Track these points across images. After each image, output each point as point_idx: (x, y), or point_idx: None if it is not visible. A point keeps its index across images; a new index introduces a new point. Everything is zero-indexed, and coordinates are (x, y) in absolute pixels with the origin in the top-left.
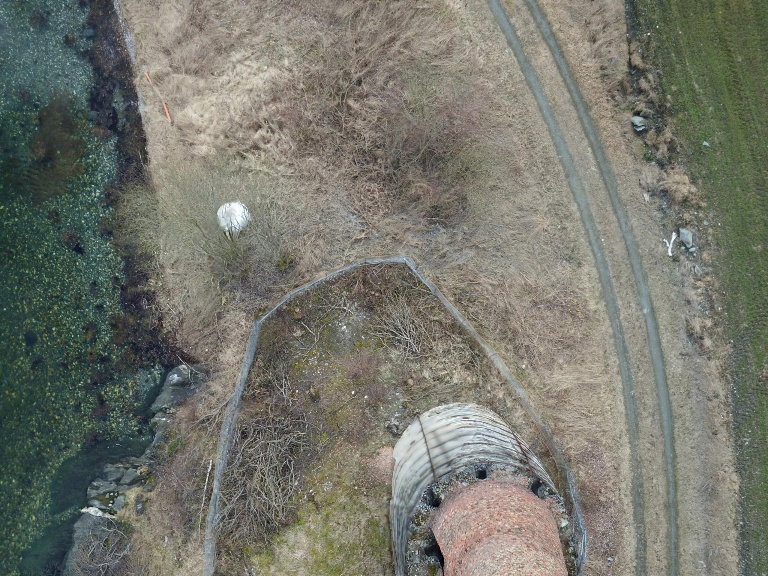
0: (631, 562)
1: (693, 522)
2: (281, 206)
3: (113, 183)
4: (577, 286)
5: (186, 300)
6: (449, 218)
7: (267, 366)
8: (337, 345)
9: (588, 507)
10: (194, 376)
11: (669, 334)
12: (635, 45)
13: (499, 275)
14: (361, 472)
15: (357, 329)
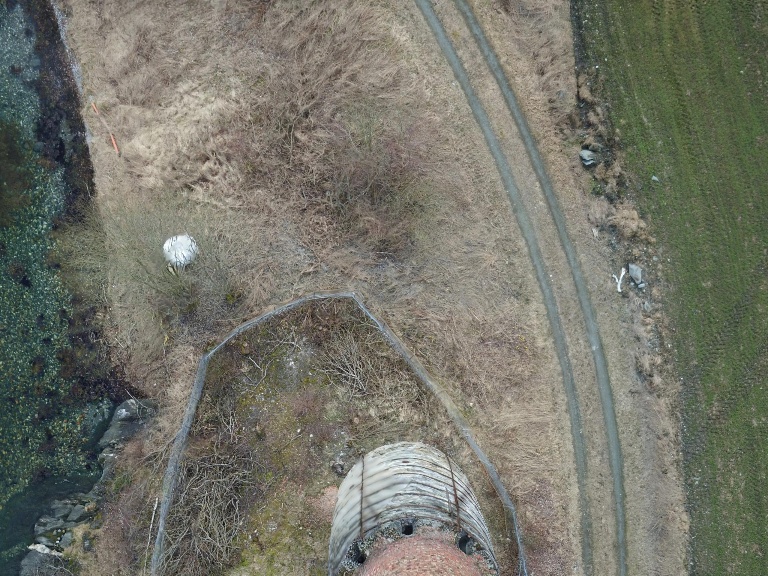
0: None
1: (643, 562)
2: (229, 239)
3: (60, 215)
4: (525, 323)
5: (134, 334)
6: (397, 252)
7: (215, 402)
8: (284, 381)
9: (535, 548)
10: (142, 411)
11: (618, 371)
12: (583, 78)
13: (447, 311)
14: (306, 512)
15: (304, 365)
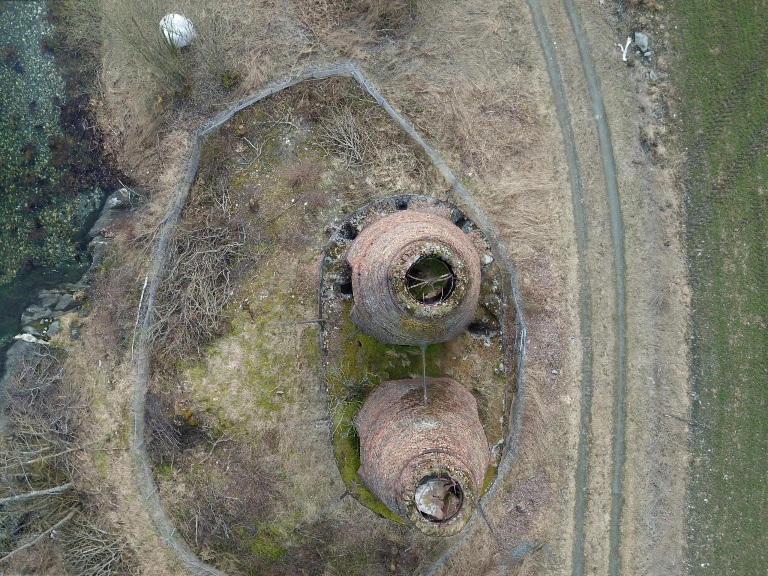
0: (577, 376)
1: (642, 336)
2: (227, 21)
3: None
4: (527, 90)
5: (127, 120)
6: (398, 28)
7: (208, 184)
8: (279, 158)
9: (532, 316)
10: (134, 199)
11: (621, 141)
12: None
13: (447, 82)
14: (298, 280)
15: (301, 142)
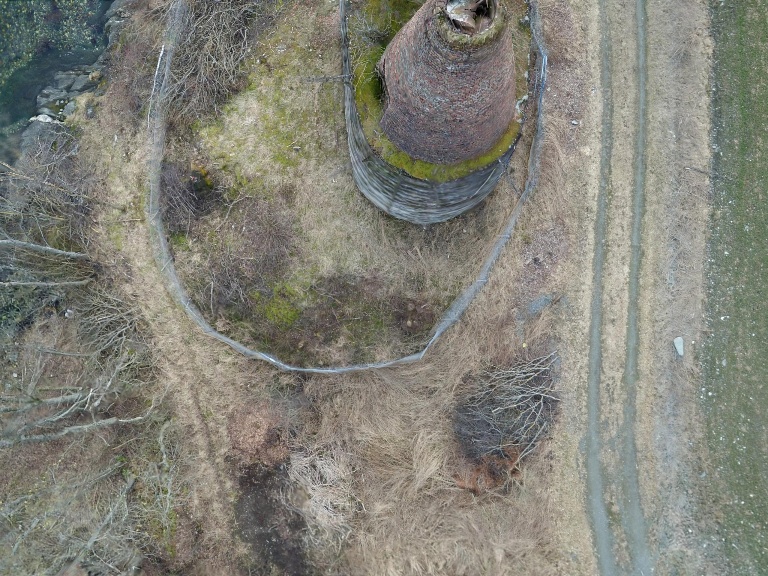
0: (596, 127)
1: (663, 89)
2: None
3: None
4: None
5: None
6: None
7: None
8: None
9: (553, 63)
10: None
11: None
12: None
13: None
14: (316, 32)
15: None
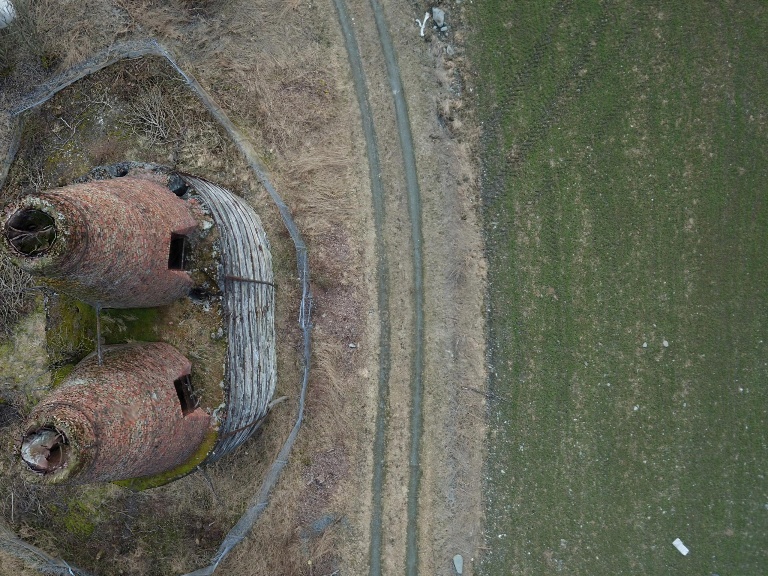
0: (374, 349)
1: (440, 310)
2: (46, 2)
3: None
4: (325, 66)
5: None
6: (208, 6)
7: (26, 164)
8: (91, 137)
9: (328, 290)
10: None
11: (419, 116)
12: None
13: (251, 59)
14: None
15: (112, 121)
